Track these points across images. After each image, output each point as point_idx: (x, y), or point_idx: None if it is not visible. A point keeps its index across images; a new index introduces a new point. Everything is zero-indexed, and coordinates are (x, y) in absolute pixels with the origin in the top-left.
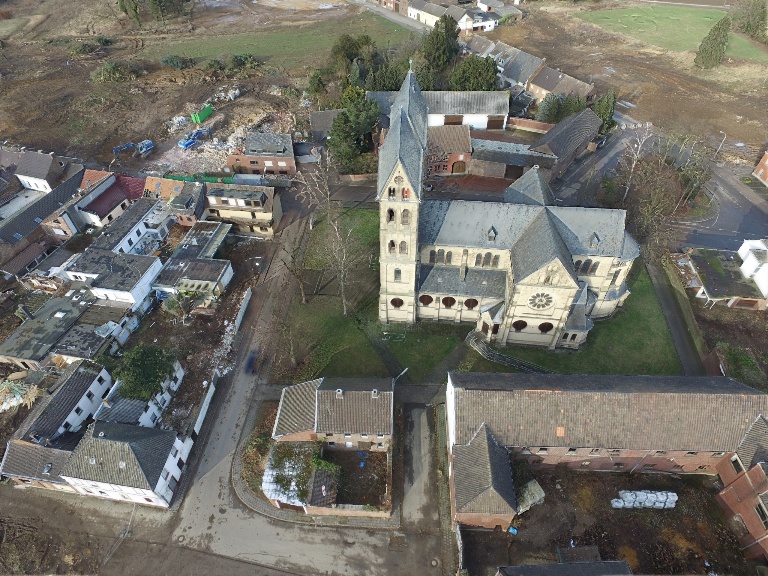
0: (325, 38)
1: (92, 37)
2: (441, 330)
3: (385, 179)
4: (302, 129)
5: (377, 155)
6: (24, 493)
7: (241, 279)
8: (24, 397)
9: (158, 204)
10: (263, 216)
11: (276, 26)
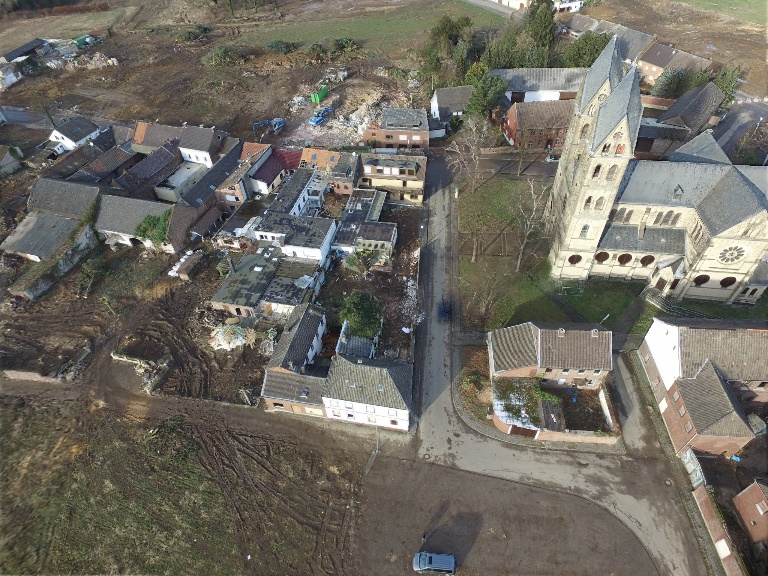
0: (413, 22)
1: (189, 26)
2: (613, 286)
3: (604, 135)
4: (419, 107)
5: (501, 130)
6: (275, 416)
7: (405, 241)
8: (245, 338)
9: (316, 173)
10: (414, 184)
11: (361, 12)
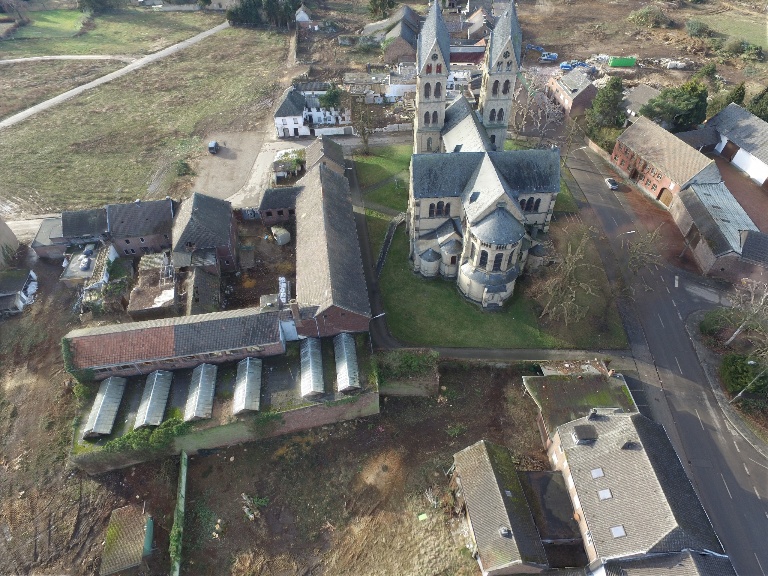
0: None
1: None
2: None
3: None
4: None
5: None
6: None
7: None
8: None
9: None
10: None
11: None
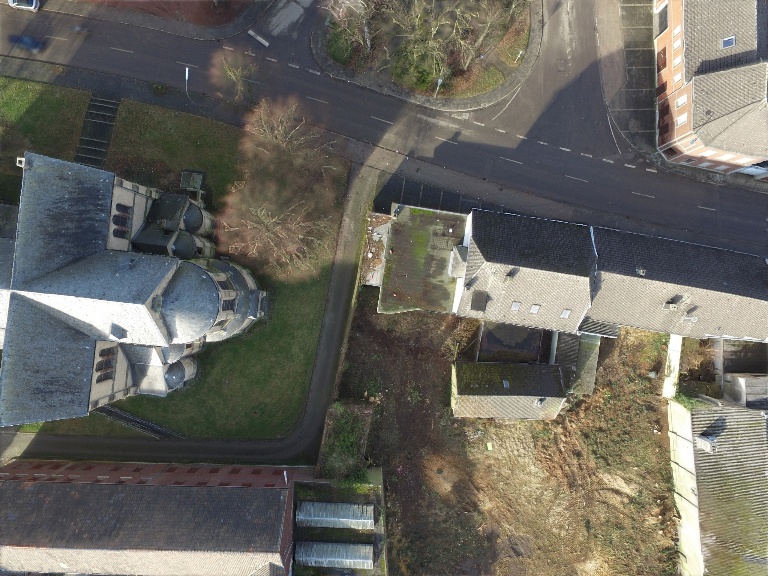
0: None
1: None
2: None
3: None
4: None
5: None
6: None
7: None
8: None
9: None
10: None
11: None
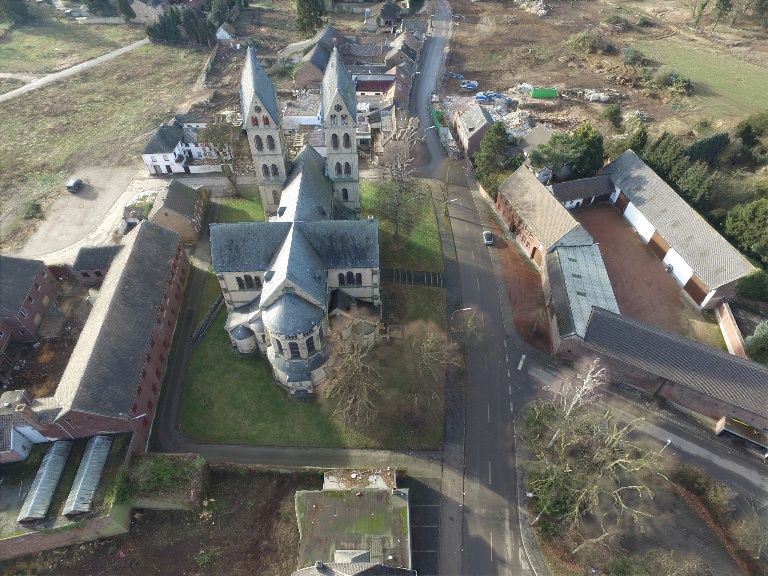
0: None
1: (651, 17)
2: None
3: None
4: None
5: None
6: None
7: None
8: None
9: None
10: None
11: None
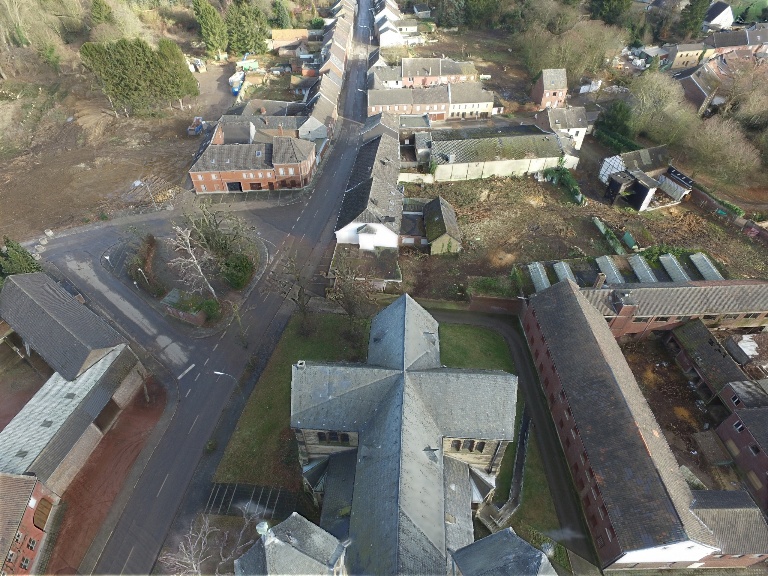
0: None
1: None
2: None
3: None
4: None
5: None
6: None
7: None
8: None
9: None
10: None
11: None
